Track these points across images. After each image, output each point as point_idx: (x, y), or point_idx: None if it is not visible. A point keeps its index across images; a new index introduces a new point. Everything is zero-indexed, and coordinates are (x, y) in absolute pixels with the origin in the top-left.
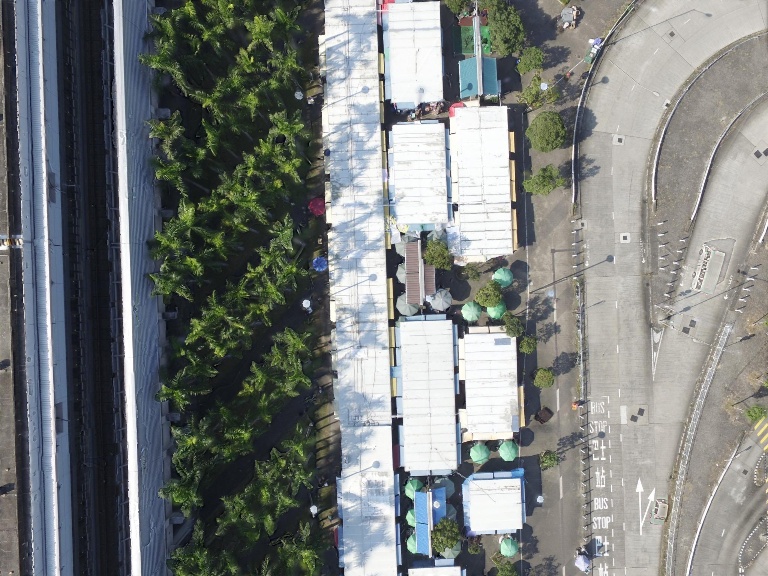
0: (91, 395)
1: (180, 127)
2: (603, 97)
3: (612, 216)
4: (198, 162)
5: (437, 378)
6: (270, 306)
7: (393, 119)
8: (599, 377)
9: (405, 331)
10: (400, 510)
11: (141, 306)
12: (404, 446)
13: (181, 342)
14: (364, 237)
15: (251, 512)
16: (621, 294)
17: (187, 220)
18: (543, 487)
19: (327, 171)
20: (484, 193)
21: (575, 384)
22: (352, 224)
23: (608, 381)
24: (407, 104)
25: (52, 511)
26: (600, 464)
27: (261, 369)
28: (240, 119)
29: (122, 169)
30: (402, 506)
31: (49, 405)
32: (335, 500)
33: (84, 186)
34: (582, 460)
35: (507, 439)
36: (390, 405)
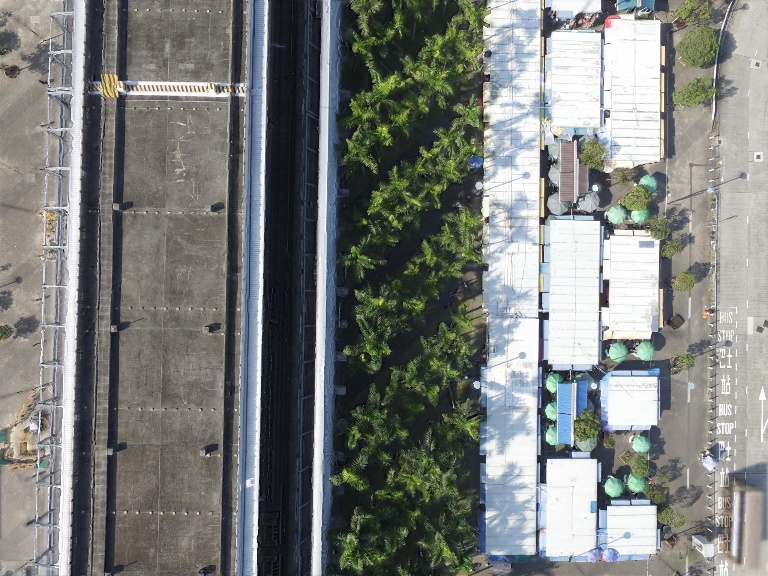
0: (267, 263)
1: (381, 1)
2: (743, 23)
3: (747, 135)
4: (385, 43)
5: (583, 276)
6: (445, 186)
7: (546, 30)
8: (728, 288)
9: (555, 229)
10: (541, 402)
11: (329, 173)
12: (549, 340)
13: (362, 213)
14: (520, 136)
15: (422, 380)
16: (752, 210)
17: (383, 90)
18: (672, 391)
19: (487, 72)
20: (635, 102)
21: (706, 293)
22: (509, 123)
23: (737, 292)
24: (566, 13)
25: (256, 352)
26: (726, 372)
27: (432, 247)
28: (422, 7)
29: (325, 36)
30: (542, 399)
31: (259, 249)
32: (475, 392)
33: (270, 60)
34: (710, 367)
35: (645, 339)
36: (537, 299)
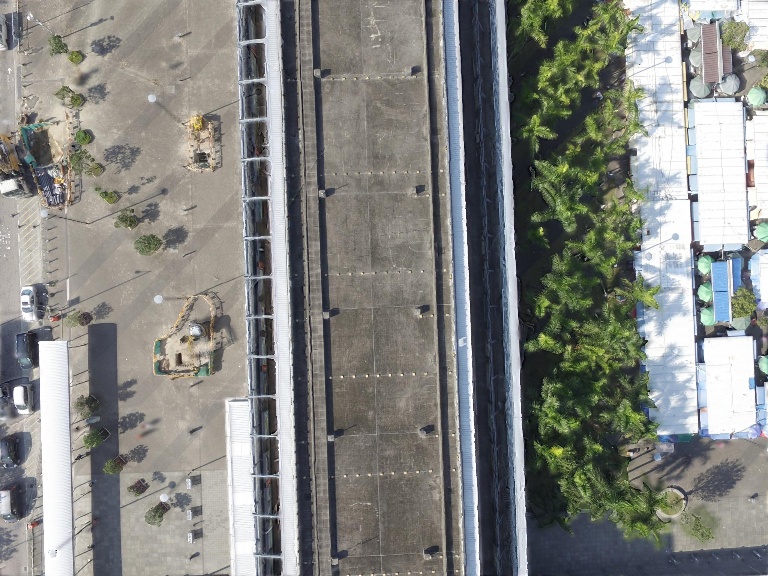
0: None
1: None
2: None
3: None
4: None
5: (729, 156)
6: (606, 62)
7: None
8: None
9: (699, 111)
10: None
11: None
12: (699, 221)
13: (531, 88)
14: (660, 21)
15: (600, 251)
16: None
17: None
18: None
19: None
20: None
21: None
22: (649, 9)
23: None
24: None
25: (461, 212)
26: None
27: (595, 123)
28: None
29: None
30: None
31: (457, 111)
32: None
33: None
34: None
35: None
36: (686, 181)
